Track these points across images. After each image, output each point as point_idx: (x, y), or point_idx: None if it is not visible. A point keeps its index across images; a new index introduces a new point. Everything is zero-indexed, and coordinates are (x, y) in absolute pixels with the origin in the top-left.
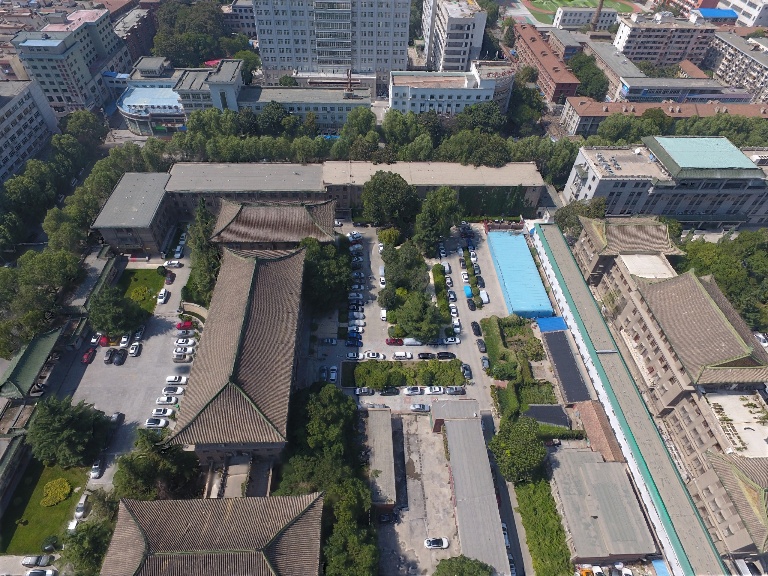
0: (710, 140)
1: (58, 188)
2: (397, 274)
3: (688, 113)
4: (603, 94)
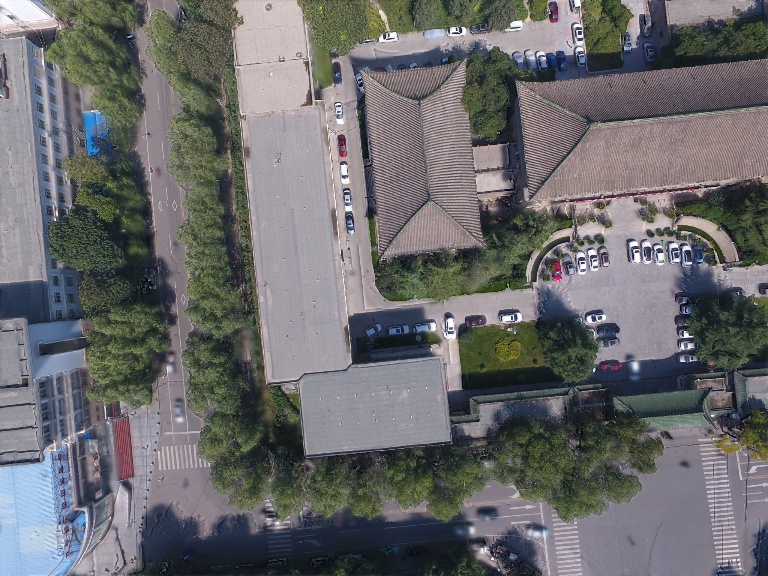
0: None
1: (311, 571)
2: None
3: None
4: None
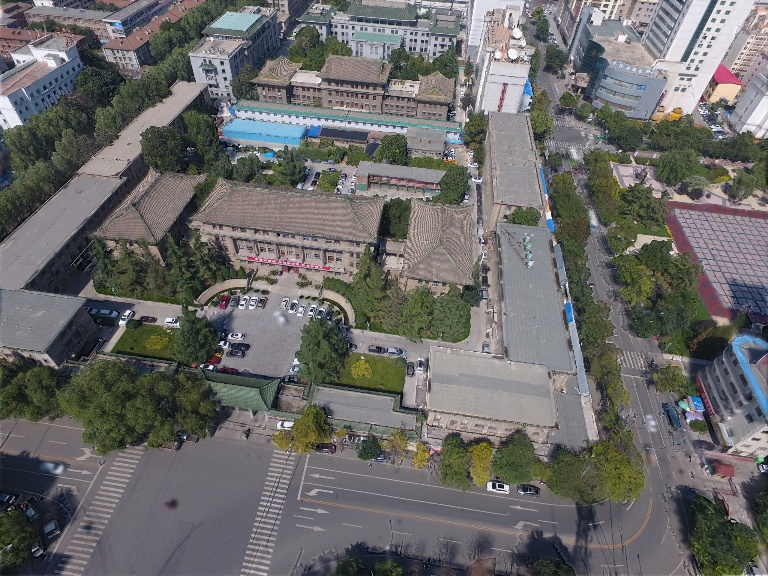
0: (227, 15)
1: None
2: (246, 170)
3: (173, 19)
4: (96, 41)
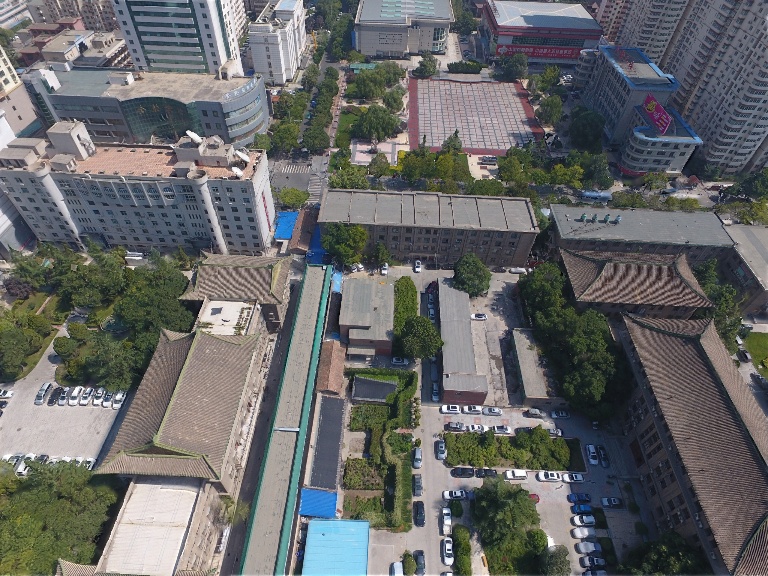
0: None
1: None
2: None
3: None
4: None
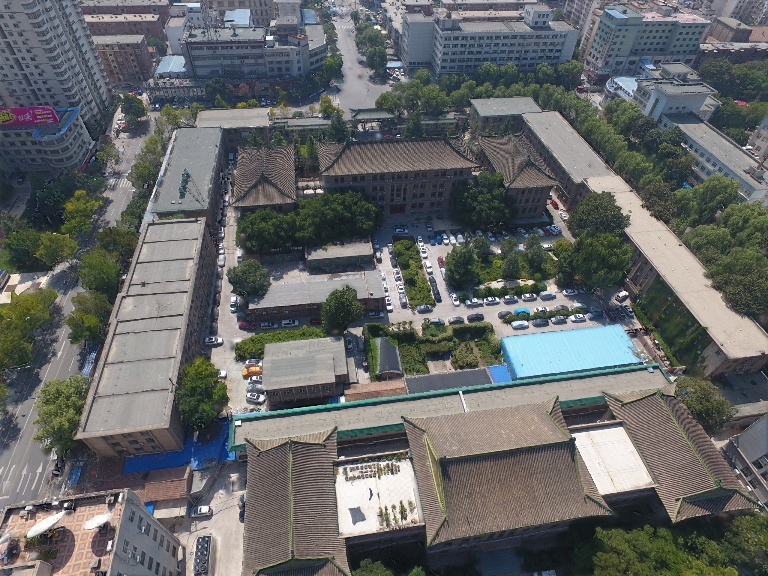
0: None
1: None
2: None
3: None
4: None
